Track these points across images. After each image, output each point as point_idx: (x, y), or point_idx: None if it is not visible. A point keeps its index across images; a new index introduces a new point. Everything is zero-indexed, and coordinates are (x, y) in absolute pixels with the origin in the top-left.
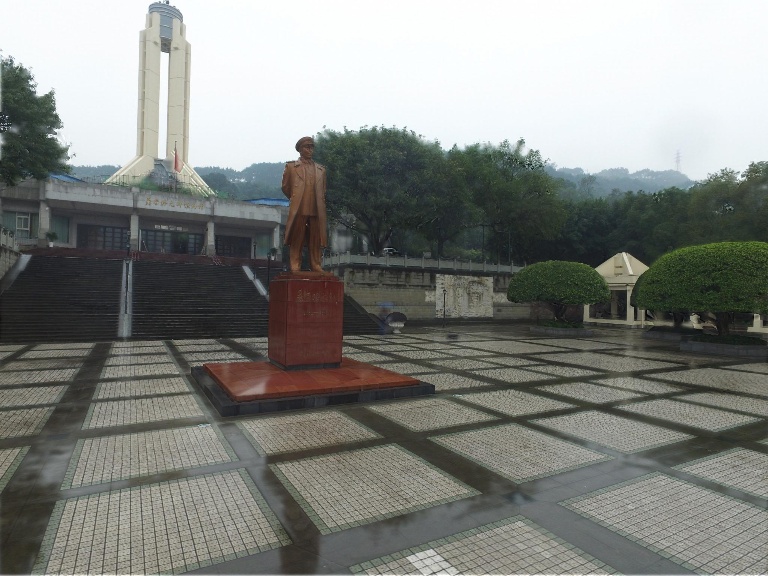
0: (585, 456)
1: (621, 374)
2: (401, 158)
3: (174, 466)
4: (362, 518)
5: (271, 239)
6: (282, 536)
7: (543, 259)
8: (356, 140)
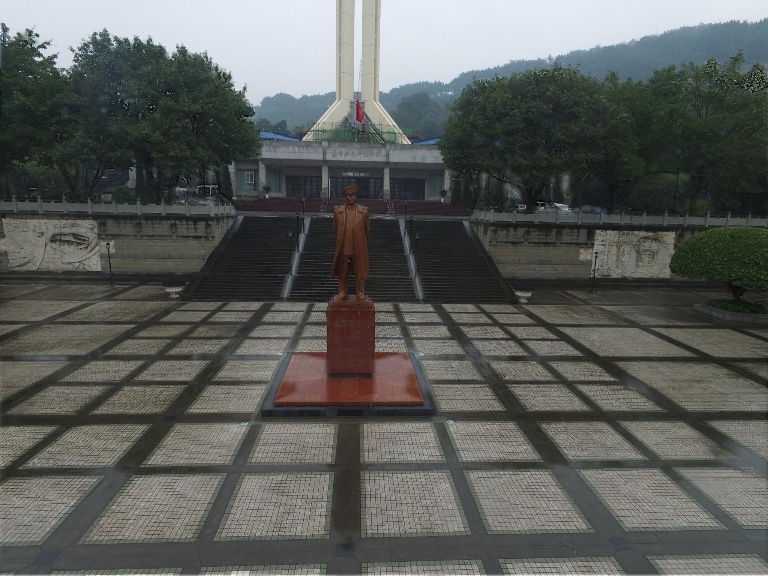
0: (449, 525)
1: (682, 415)
2: (546, 112)
3: (198, 461)
4: (242, 535)
5: (443, 180)
6: (196, 535)
7: (762, 206)
8: (498, 95)
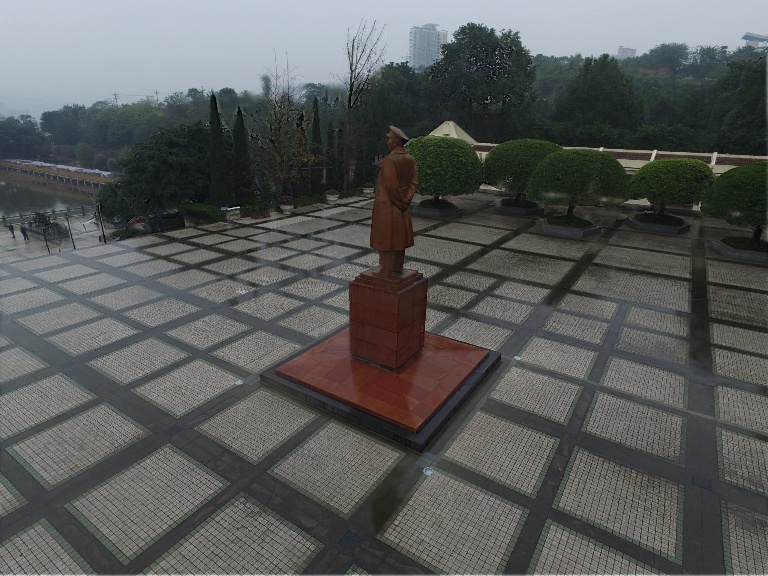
0: None
1: None
2: None
3: None
4: None
5: None
6: None
7: None
8: None
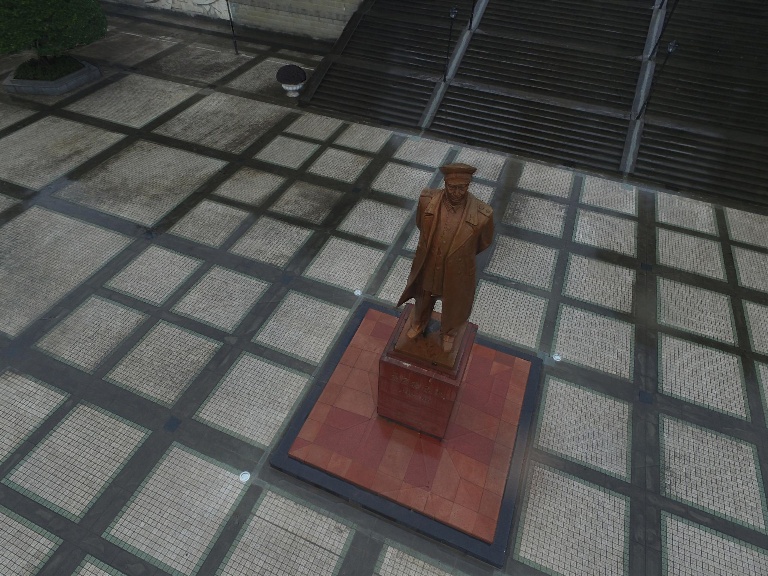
0: None
1: None
2: None
3: (159, 555)
4: None
5: None
6: None
7: None
8: None
